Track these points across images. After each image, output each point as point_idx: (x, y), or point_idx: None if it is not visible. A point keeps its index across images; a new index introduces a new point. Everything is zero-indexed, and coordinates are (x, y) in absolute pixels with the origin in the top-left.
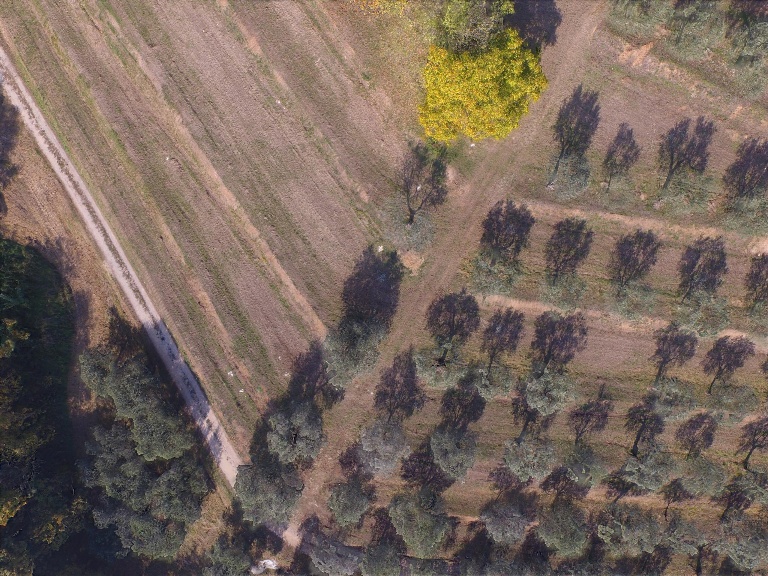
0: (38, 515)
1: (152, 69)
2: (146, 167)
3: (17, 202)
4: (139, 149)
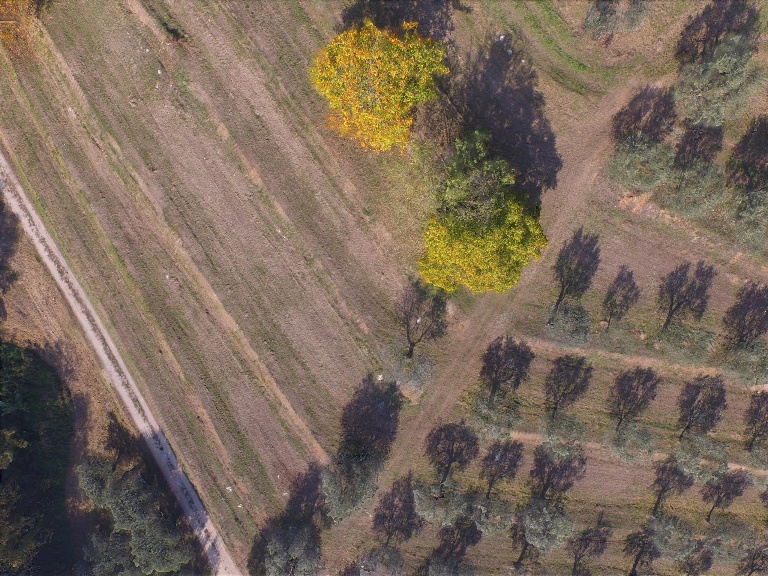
0: None
1: (153, 192)
2: (146, 283)
3: (17, 307)
4: (139, 265)
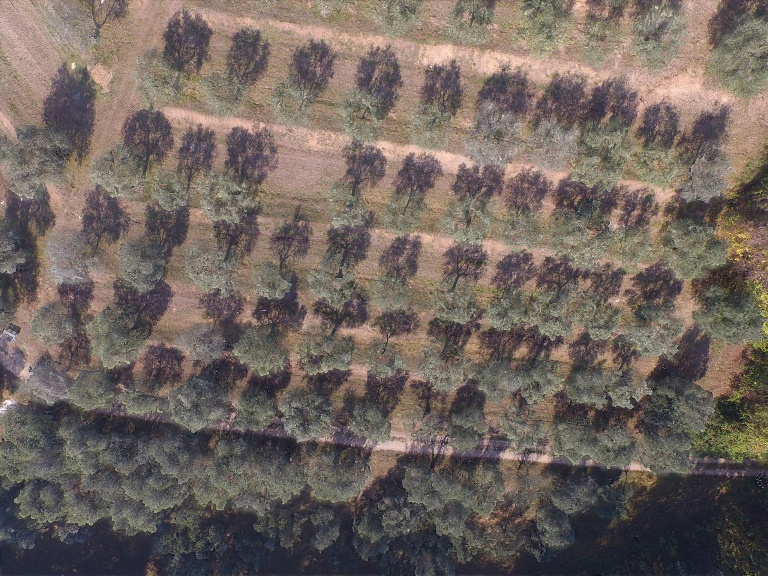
0: None
1: None
2: None
3: None
4: None
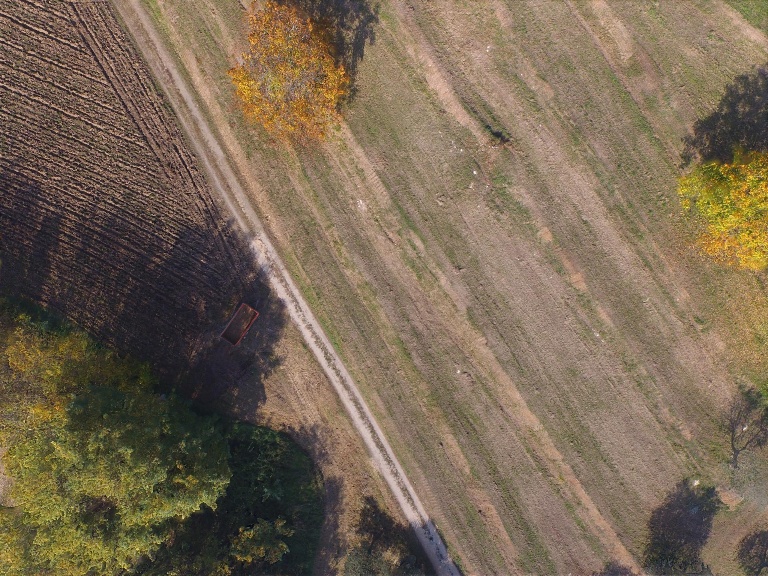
0: None
1: (457, 290)
2: (433, 377)
3: (276, 392)
4: (427, 359)
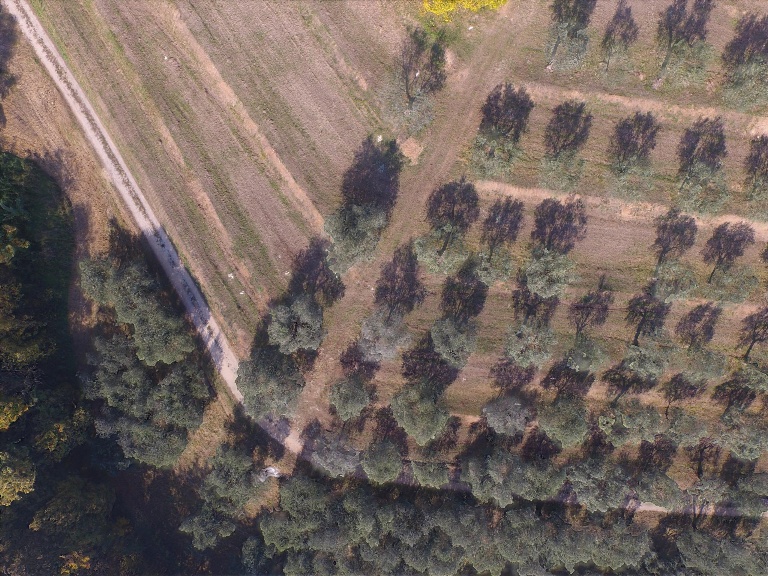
0: (40, 424)
1: None
2: (144, 68)
3: (16, 113)
4: (137, 50)
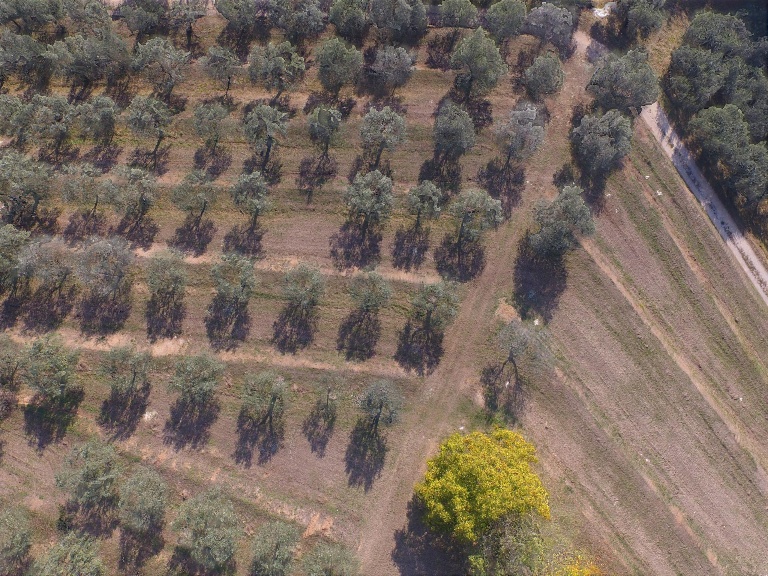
0: None
1: None
2: (760, 390)
3: None
4: None
